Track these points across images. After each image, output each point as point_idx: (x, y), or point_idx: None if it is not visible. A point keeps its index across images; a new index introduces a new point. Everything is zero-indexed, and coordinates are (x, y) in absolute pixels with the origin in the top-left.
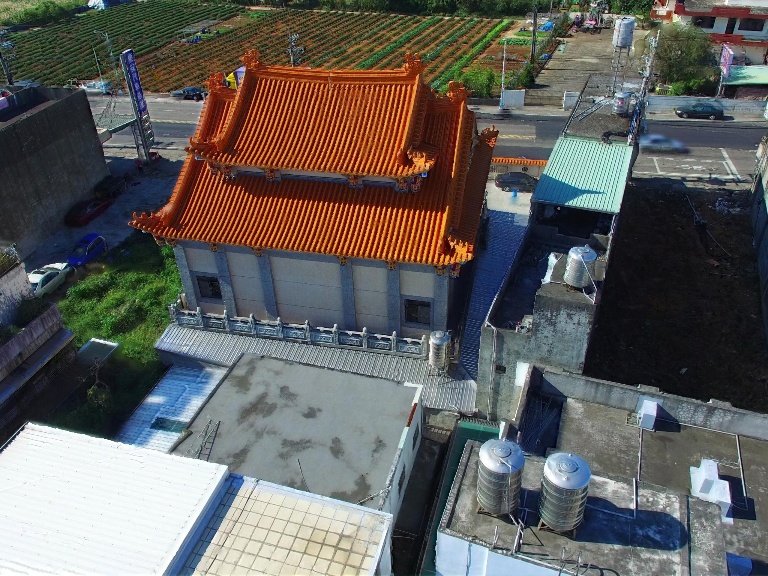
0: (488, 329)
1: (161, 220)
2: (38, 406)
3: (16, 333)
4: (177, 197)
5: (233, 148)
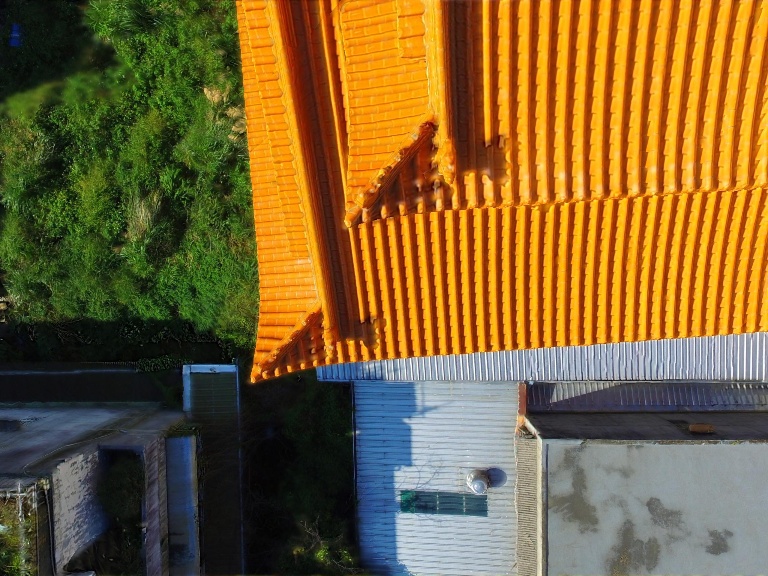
0: None
1: (330, 357)
2: (214, 530)
3: (140, 544)
4: (321, 266)
5: (481, 142)
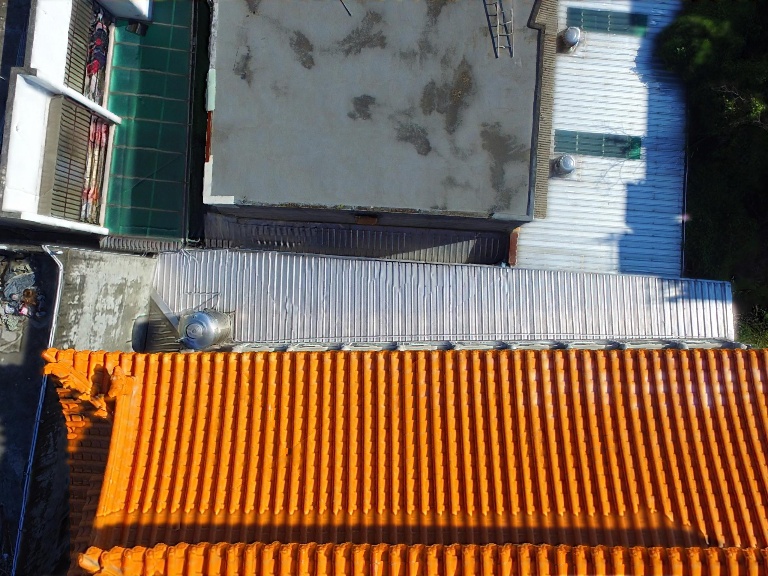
0: (59, 249)
1: None
2: None
3: None
4: None
5: None
